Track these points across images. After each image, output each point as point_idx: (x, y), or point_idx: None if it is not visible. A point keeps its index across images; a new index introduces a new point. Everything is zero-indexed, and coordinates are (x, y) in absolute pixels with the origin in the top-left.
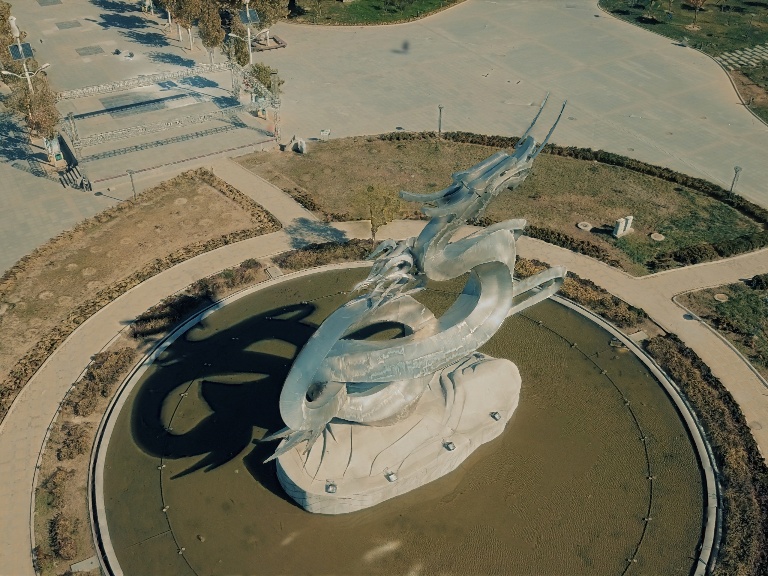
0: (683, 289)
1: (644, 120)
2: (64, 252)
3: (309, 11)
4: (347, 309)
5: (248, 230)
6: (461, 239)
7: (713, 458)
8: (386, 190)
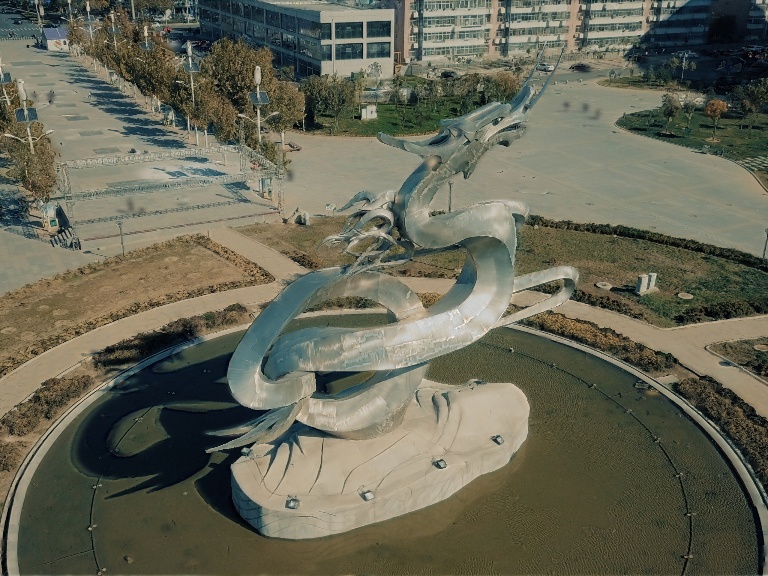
0: (717, 340)
1: (666, 206)
2: (38, 296)
3: (327, 126)
4: (316, 275)
5: (238, 281)
6: None
7: (766, 496)
8: None
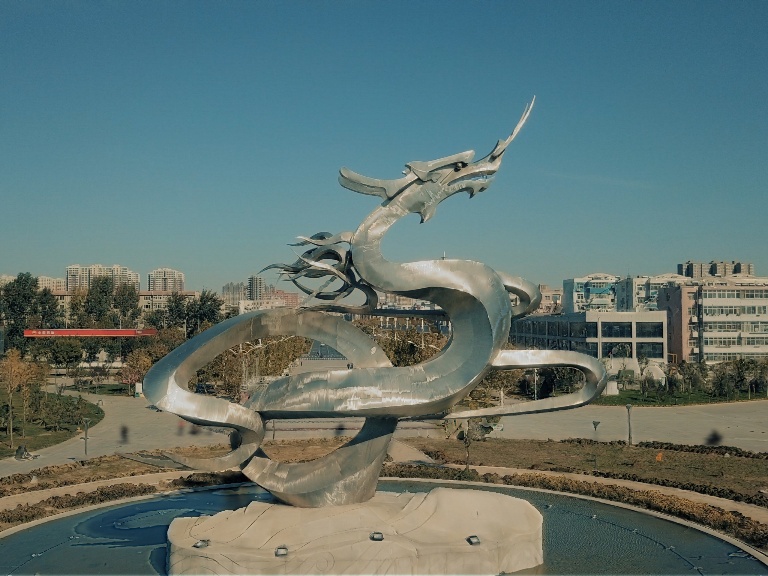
0: None
1: None
2: (179, 454)
3: None
4: None
5: None
6: None
7: None
8: (532, 459)
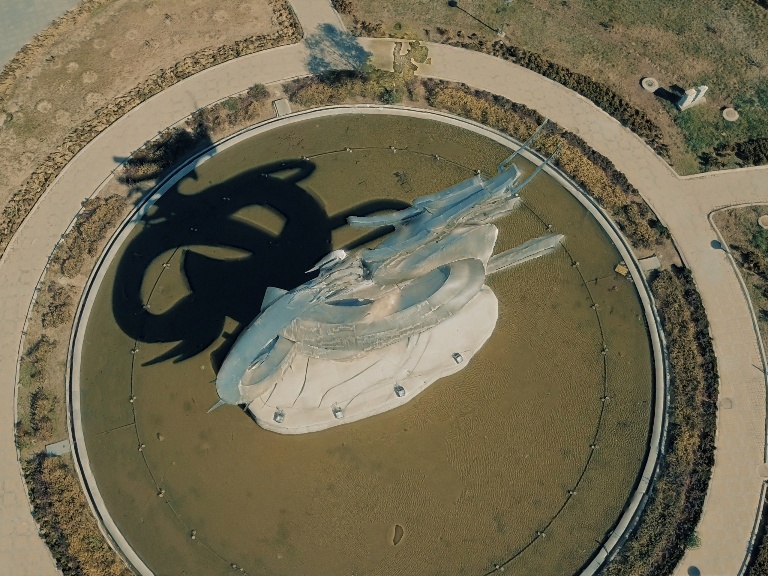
0: (727, 202)
1: None
2: (66, 43)
3: None
4: None
5: (264, 37)
6: None
7: (665, 436)
8: None
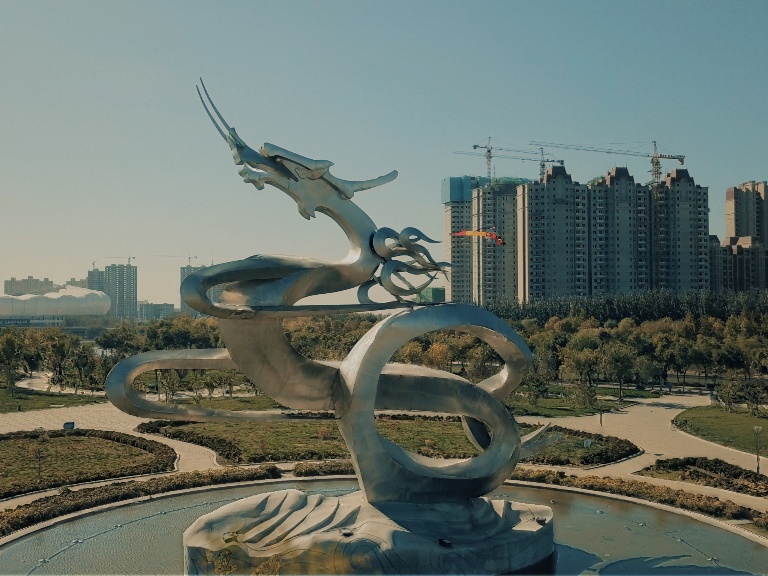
0: None
1: None
2: None
3: None
4: None
5: None
6: (306, 264)
7: None
8: None
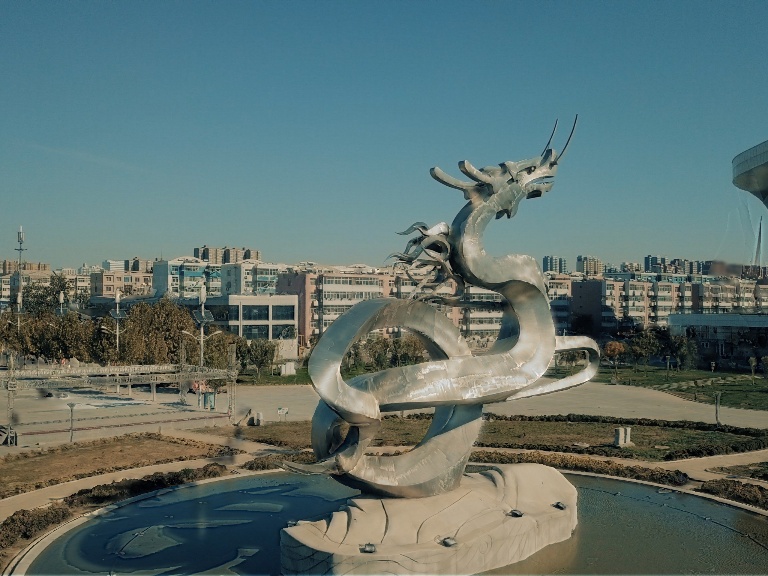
0: (712, 466)
1: (602, 408)
2: None
3: (248, 380)
4: None
5: (207, 453)
6: None
7: None
8: None
